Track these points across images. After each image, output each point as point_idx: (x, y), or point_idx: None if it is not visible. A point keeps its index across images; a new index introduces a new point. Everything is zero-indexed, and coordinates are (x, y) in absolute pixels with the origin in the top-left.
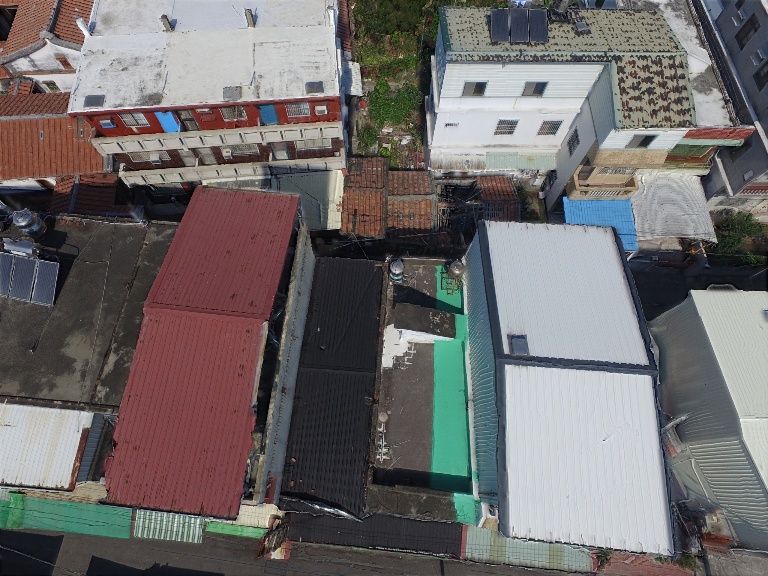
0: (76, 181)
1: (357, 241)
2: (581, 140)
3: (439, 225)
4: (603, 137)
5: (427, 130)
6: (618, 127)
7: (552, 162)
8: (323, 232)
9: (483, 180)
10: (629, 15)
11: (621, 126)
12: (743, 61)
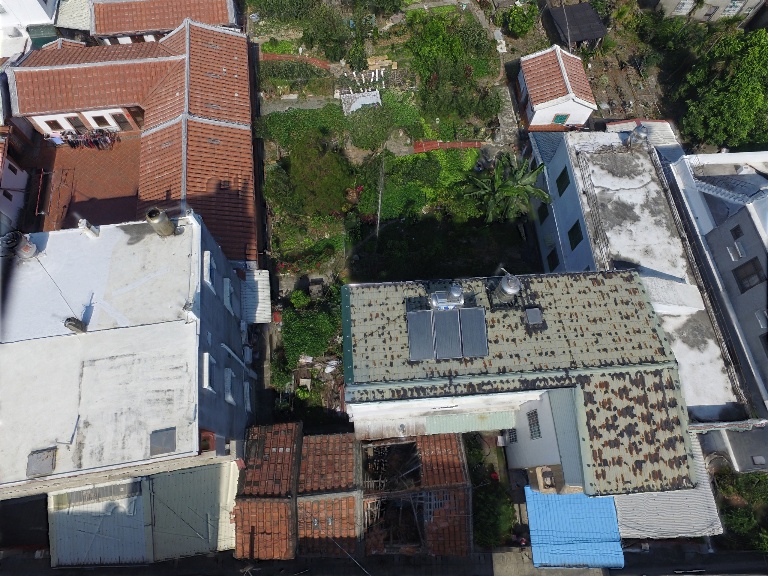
0: None
1: None
2: (543, 436)
3: (367, 524)
4: (570, 478)
5: None
6: (589, 494)
7: (510, 419)
8: None
9: (424, 443)
10: (597, 285)
11: (593, 492)
12: (745, 310)
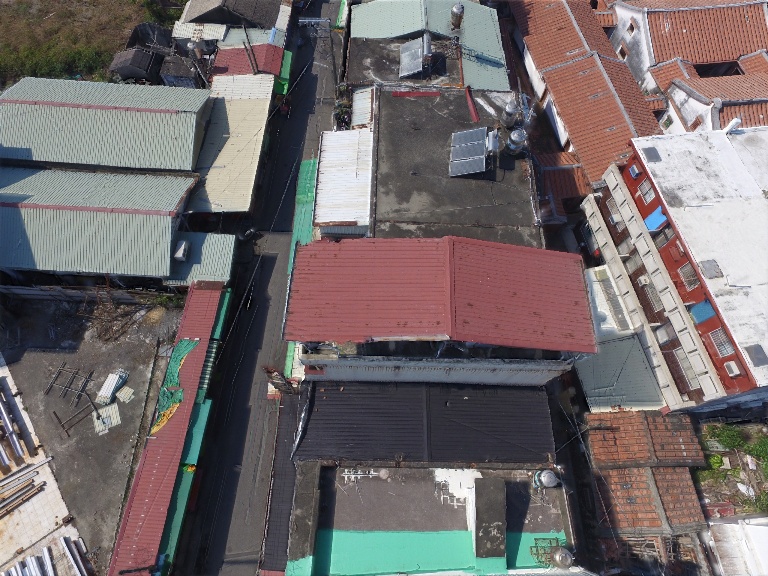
0: (575, 165)
1: (578, 432)
2: None
3: (630, 540)
4: None
5: (767, 517)
6: None
7: None
8: (582, 394)
9: None
10: None
11: None
12: None
